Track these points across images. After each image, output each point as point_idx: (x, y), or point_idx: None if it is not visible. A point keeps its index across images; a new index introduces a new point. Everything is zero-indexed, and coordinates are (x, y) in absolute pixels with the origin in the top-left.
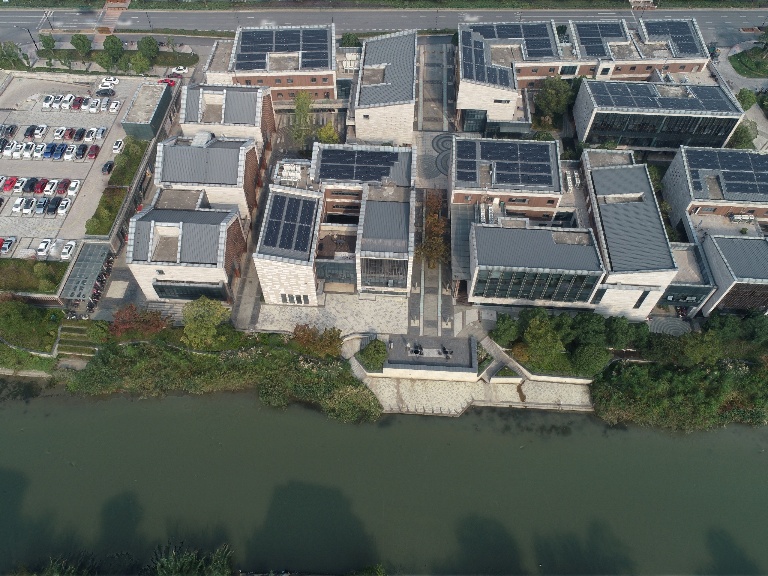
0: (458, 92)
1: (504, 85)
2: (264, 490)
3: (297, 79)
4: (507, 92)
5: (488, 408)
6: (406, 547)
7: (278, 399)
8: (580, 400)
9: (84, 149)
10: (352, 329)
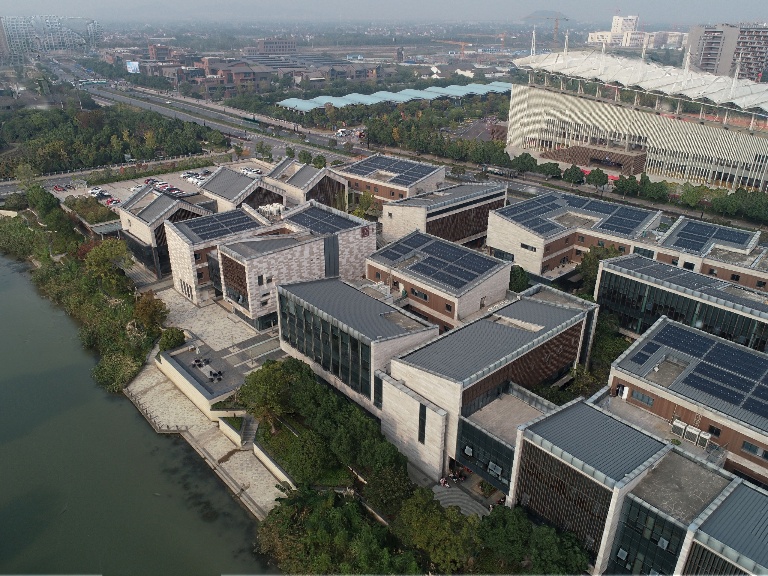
0: (488, 225)
1: (536, 231)
2: None
3: (381, 189)
4: (533, 236)
5: (188, 446)
6: None
7: None
8: (266, 503)
9: None
10: (191, 327)
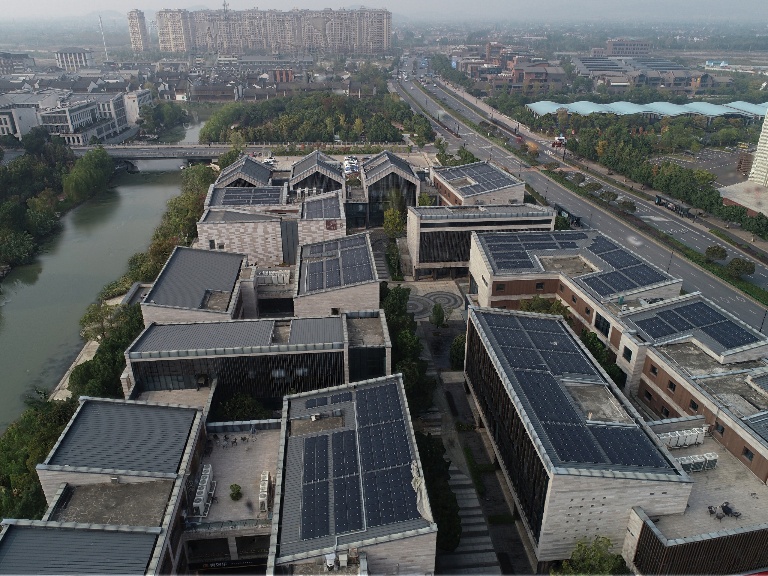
0: None
1: (498, 264)
2: None
3: None
4: None
5: None
6: None
7: None
8: None
9: None
10: None
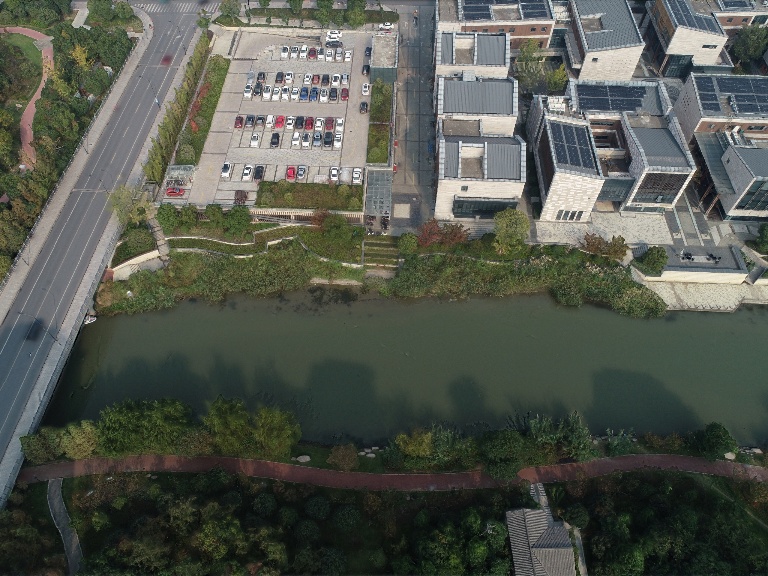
0: (672, 38)
1: (713, 31)
2: (582, 373)
3: (519, 28)
4: (718, 37)
5: (757, 305)
6: (721, 415)
7: (576, 298)
8: None
9: (336, 92)
10: None
